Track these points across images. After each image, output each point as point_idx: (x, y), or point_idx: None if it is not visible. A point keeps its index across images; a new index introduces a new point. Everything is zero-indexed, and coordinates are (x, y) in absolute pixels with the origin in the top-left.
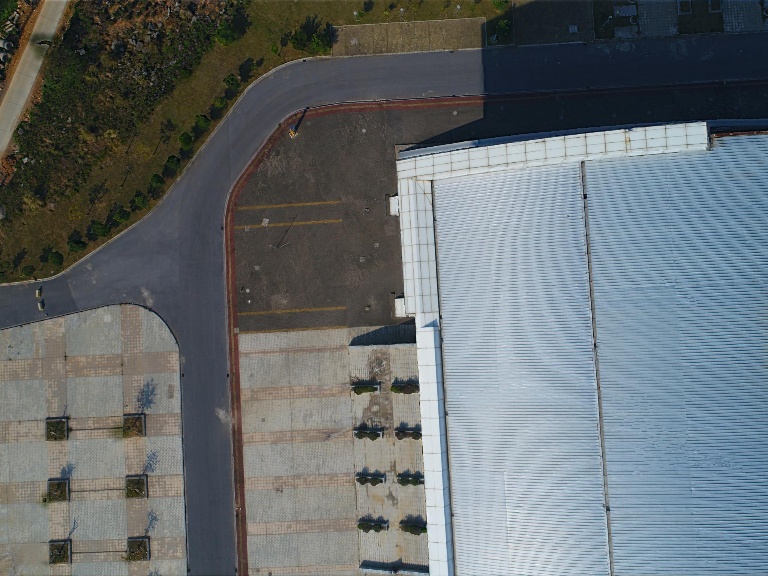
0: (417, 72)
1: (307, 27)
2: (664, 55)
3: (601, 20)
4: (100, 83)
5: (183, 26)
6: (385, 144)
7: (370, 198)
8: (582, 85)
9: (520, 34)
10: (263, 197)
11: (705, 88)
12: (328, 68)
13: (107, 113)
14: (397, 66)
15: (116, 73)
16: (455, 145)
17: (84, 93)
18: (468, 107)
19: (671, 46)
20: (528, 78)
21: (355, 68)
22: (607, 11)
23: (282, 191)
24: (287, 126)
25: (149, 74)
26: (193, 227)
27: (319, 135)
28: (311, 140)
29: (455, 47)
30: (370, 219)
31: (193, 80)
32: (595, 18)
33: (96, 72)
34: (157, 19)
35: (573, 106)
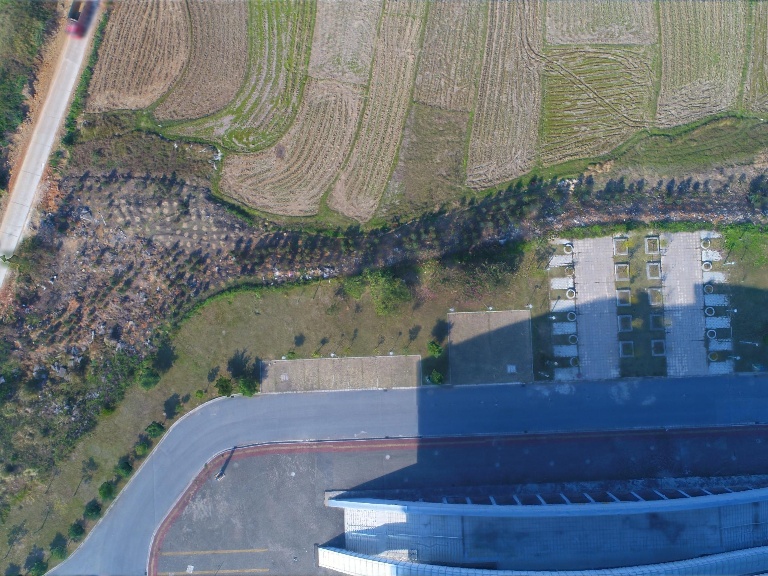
0: (349, 411)
1: (235, 362)
2: (605, 399)
3: (540, 361)
4: (19, 418)
5: (107, 353)
6: (315, 489)
7: (298, 547)
8: (520, 429)
9: (456, 373)
10: (188, 542)
11: (646, 436)
12: (257, 405)
13: (26, 450)
14: (328, 404)
15: (36, 407)
16: (384, 507)
17: (3, 428)
18: (401, 451)
19: (612, 389)
20: (464, 420)
21: (285, 406)
22: (547, 351)
23: (208, 537)
24: (214, 467)
25: (71, 408)
26: (115, 572)
27: (246, 478)
28: (238, 483)
29: (389, 386)
30: (298, 569)
31: (116, 416)
32: (534, 358)
33: (15, 408)
34: (81, 343)
35: (510, 452)
